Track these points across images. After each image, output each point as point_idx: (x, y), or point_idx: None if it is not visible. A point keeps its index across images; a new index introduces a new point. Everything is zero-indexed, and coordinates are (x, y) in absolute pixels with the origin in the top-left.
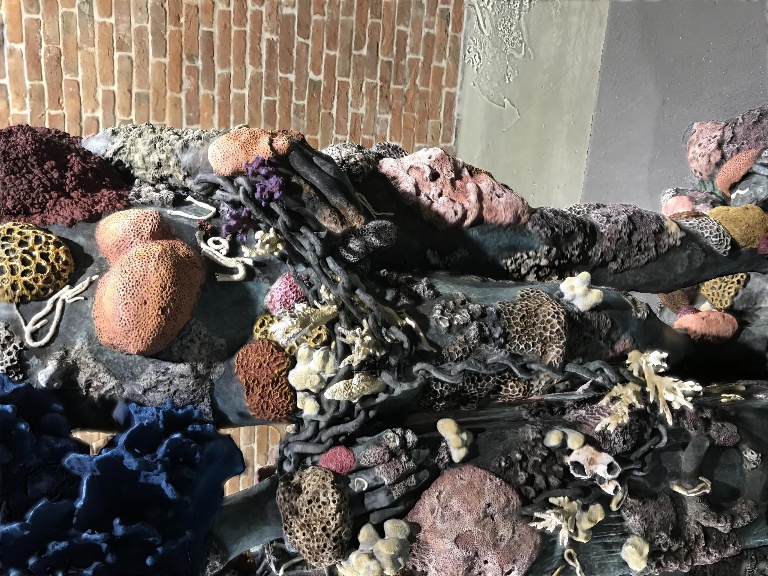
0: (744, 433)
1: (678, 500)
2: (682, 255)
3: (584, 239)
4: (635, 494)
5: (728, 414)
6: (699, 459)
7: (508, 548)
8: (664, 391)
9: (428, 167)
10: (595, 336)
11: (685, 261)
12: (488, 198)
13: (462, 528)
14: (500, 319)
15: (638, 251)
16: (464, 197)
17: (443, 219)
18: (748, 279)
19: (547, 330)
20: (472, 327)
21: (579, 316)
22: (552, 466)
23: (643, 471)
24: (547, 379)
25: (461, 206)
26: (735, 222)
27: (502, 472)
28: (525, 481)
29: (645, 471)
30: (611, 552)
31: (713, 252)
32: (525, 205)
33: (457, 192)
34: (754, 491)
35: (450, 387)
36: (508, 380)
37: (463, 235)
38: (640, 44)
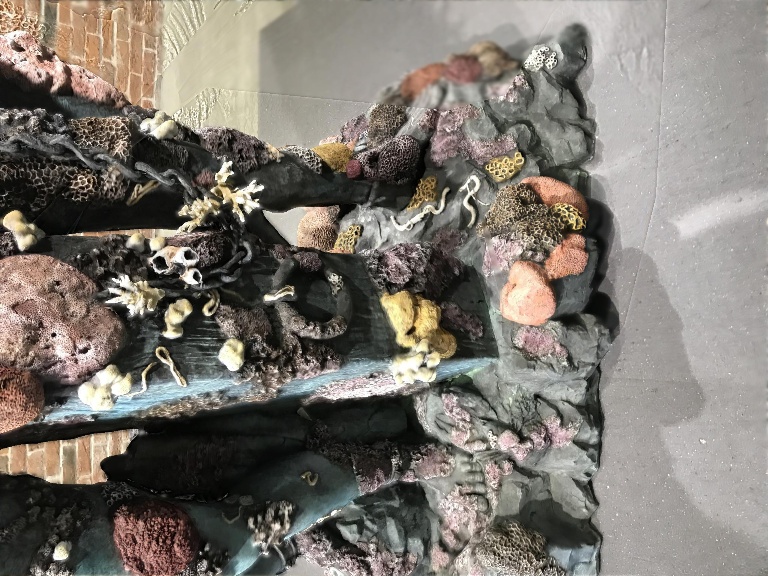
0: (326, 261)
1: (273, 315)
2: (282, 169)
3: (185, 138)
4: (227, 302)
5: (313, 251)
6: (285, 274)
7: (81, 323)
8: (236, 197)
9: (10, 38)
10: (173, 161)
11: (286, 174)
12: (77, 75)
13: (22, 297)
14: (68, 125)
15: (240, 158)
16: (50, 69)
17: (25, 79)
18: (362, 229)
19: (113, 129)
20: (32, 117)
21: (154, 140)
22: (137, 269)
23: (230, 276)
24: (117, 173)
25: (45, 71)
26: (324, 150)
27: (79, 267)
28: (104, 273)
29: (232, 276)
30: (208, 354)
31: (309, 171)
32: (119, 93)
33: (43, 64)
34: (342, 309)
35: (8, 168)
36: (77, 174)
37: (51, 102)
38: (282, 108)
